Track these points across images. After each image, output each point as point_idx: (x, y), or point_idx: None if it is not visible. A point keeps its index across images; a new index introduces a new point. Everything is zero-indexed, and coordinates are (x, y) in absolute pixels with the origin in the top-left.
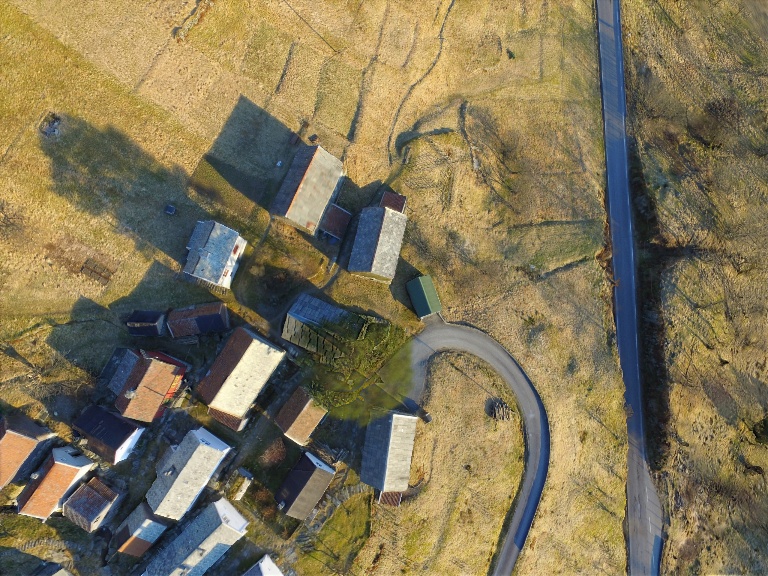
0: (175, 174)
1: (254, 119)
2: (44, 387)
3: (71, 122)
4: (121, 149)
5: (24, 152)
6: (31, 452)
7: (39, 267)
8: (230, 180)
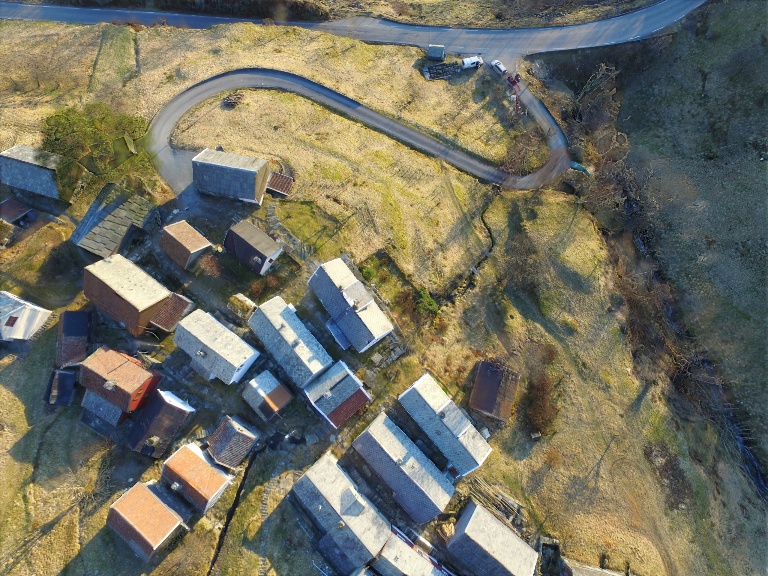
0: None
1: None
2: (97, 491)
3: None
4: None
5: None
6: None
7: None
8: None
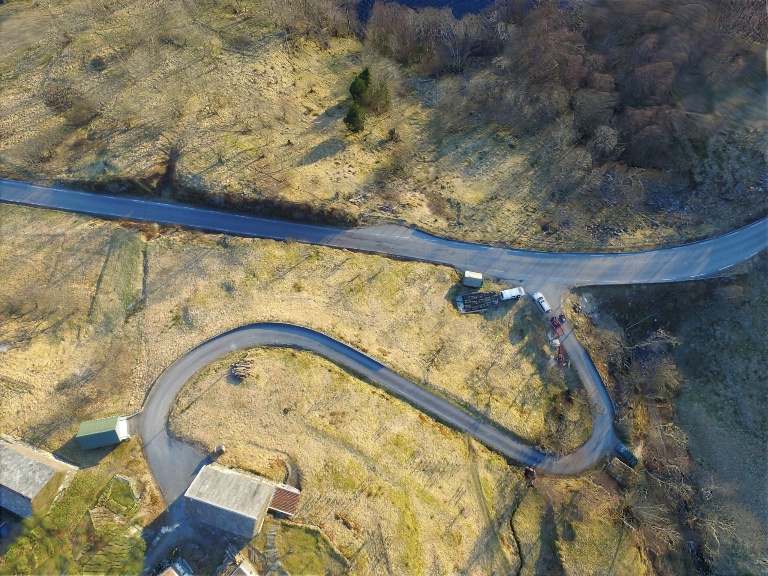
0: None
1: None
2: None
3: None
4: None
5: None
6: None
7: None
8: None
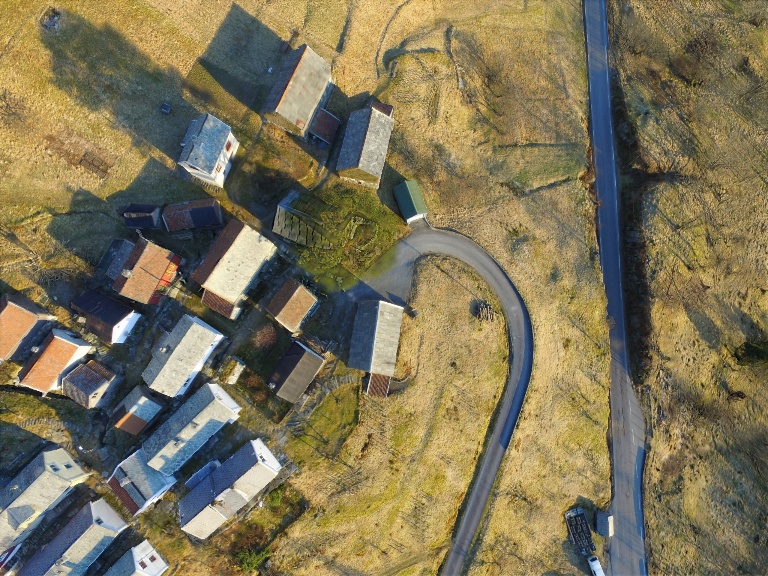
0: (170, 75)
1: (246, 27)
2: (44, 272)
3: (70, 18)
4: (118, 47)
5: (25, 43)
6: (32, 328)
7: (40, 157)
8: (223, 84)
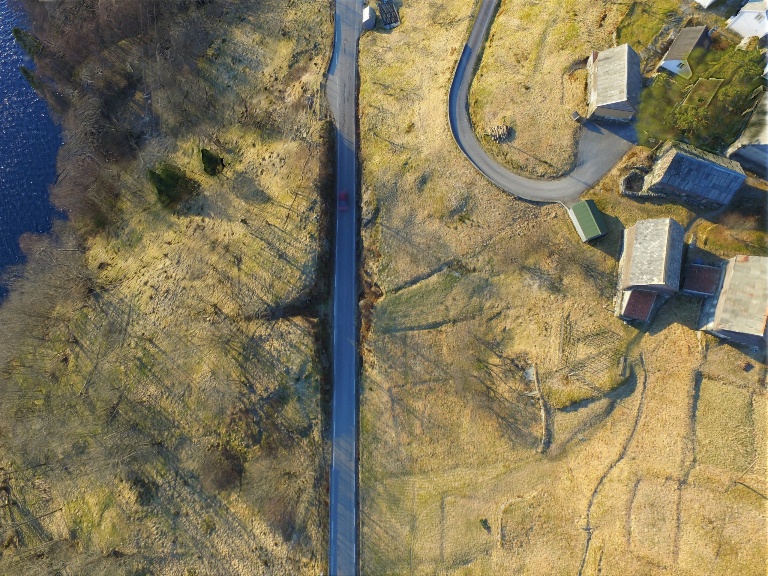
0: None
1: None
2: None
3: None
4: None
5: None
6: None
7: None
8: None
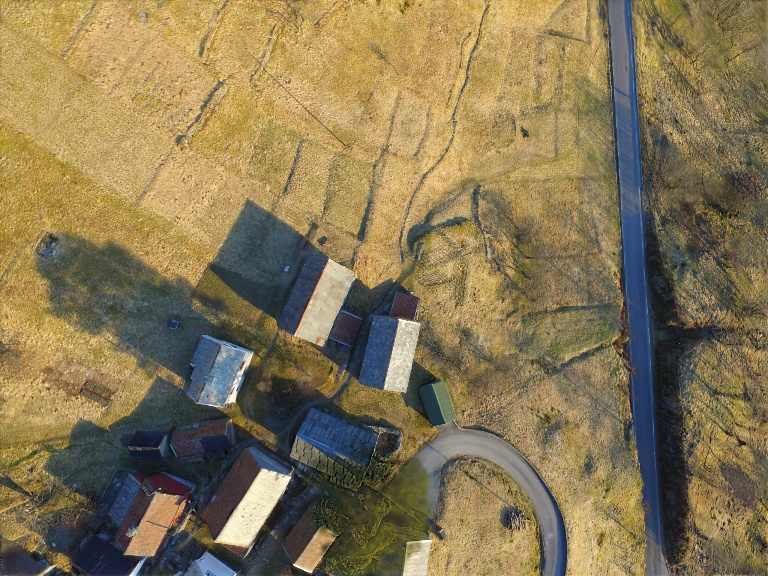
0: (178, 286)
1: (261, 223)
2: (41, 517)
3: (69, 241)
4: (122, 264)
5: (20, 276)
6: None
7: (36, 392)
8: (236, 288)
